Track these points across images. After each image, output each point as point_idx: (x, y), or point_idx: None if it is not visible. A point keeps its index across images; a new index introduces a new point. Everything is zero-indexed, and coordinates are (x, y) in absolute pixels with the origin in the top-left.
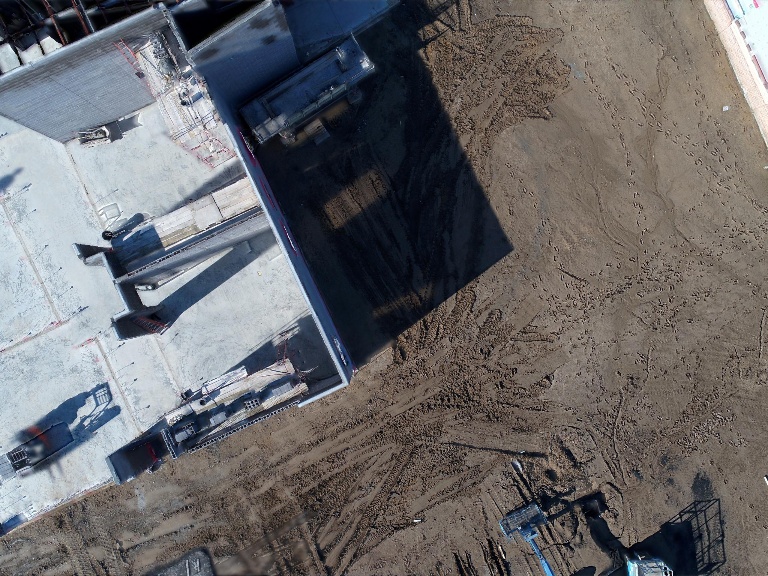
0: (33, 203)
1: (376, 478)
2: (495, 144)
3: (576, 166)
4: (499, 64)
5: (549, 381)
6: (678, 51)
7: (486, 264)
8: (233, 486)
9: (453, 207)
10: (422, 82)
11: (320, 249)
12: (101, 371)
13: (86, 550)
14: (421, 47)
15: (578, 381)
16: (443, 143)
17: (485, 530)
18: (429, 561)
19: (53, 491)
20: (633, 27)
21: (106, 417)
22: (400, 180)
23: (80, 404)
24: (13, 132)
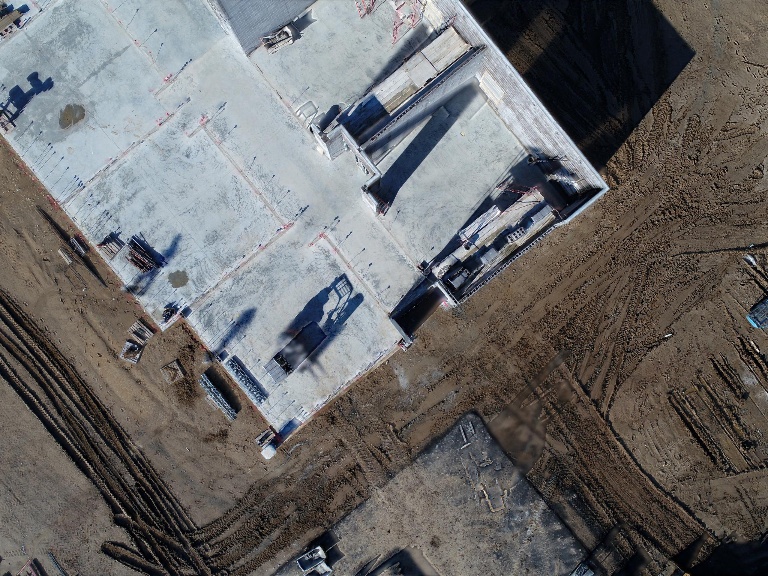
0: (232, 120)
1: (619, 304)
2: None
3: None
4: None
5: (760, 171)
6: None
7: (673, 74)
8: (486, 345)
9: (629, 26)
10: None
11: None
12: (336, 264)
13: (362, 439)
14: None
15: None
16: None
17: (734, 329)
18: (688, 372)
19: (319, 389)
20: None
21: (351, 307)
22: (572, 13)
23: (324, 301)
24: (197, 57)
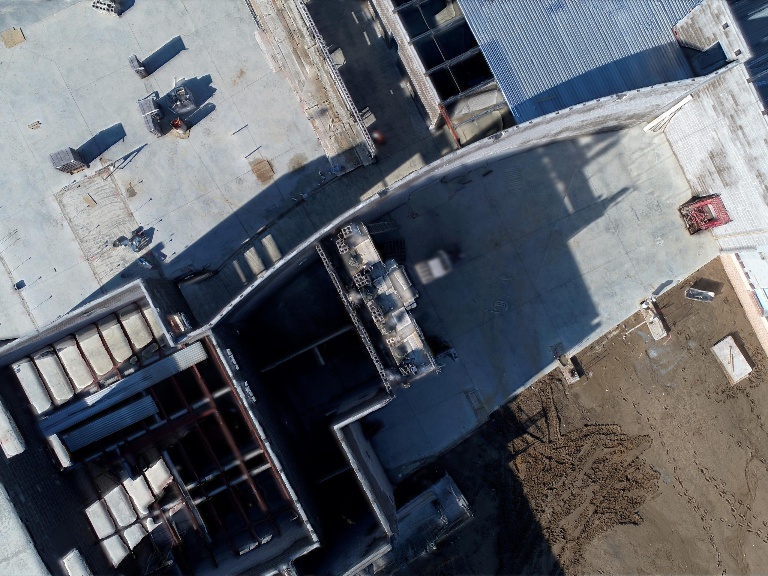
0: None
1: None
2: (587, 551)
3: (668, 568)
4: (589, 472)
5: None
6: (766, 453)
7: None
8: None
9: None
10: (513, 494)
11: None
12: None
13: None
14: (511, 460)
15: None
16: (536, 554)
17: None
18: None
19: None
20: (721, 431)
21: None
22: None
23: None
24: None
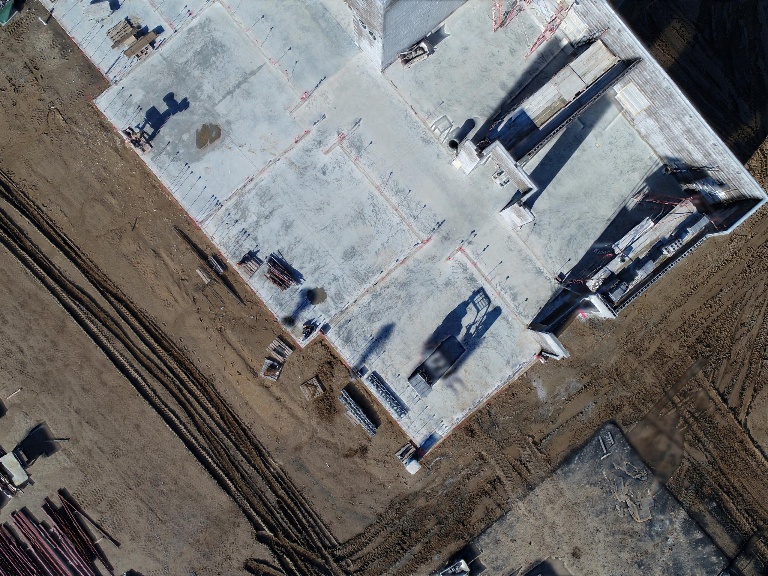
0: (368, 136)
1: (755, 311)
2: None
3: None
4: None
5: None
6: None
7: None
8: (623, 355)
9: (760, 34)
10: None
11: None
12: (473, 278)
13: (502, 452)
14: None
15: None
16: None
17: None
18: None
19: (459, 403)
20: None
21: (490, 320)
22: (703, 22)
23: (462, 314)
24: (331, 74)
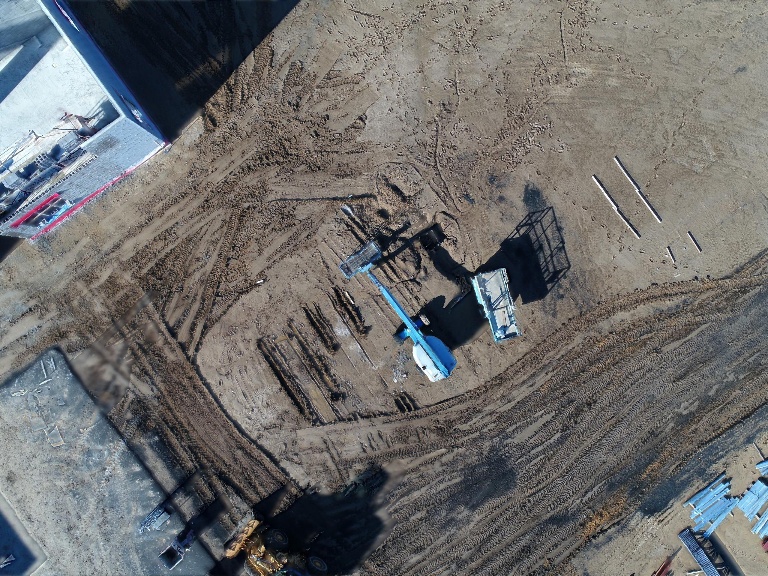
0: None
1: (211, 247)
2: None
3: None
4: None
5: (362, 121)
6: None
7: (277, 18)
8: (72, 281)
9: None
10: None
11: (110, 32)
12: None
13: None
14: None
15: (391, 117)
16: None
17: (329, 279)
18: (280, 319)
19: None
20: None
21: None
22: None
23: None
24: None
